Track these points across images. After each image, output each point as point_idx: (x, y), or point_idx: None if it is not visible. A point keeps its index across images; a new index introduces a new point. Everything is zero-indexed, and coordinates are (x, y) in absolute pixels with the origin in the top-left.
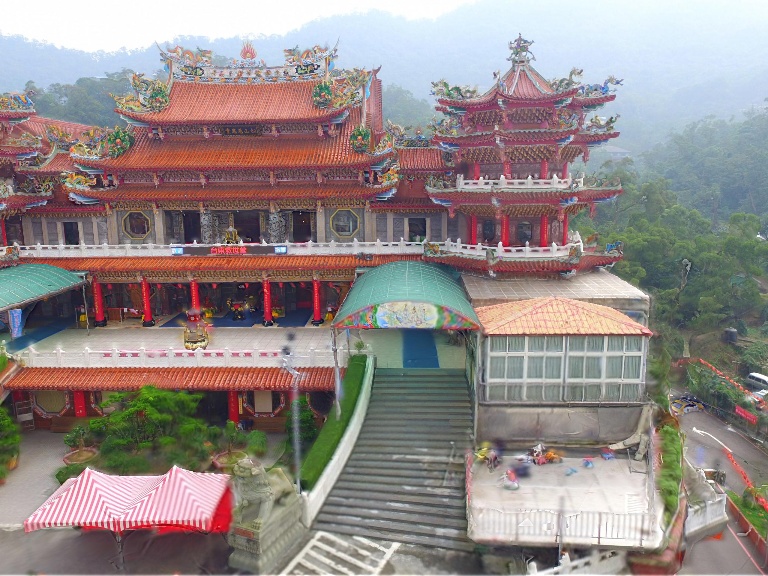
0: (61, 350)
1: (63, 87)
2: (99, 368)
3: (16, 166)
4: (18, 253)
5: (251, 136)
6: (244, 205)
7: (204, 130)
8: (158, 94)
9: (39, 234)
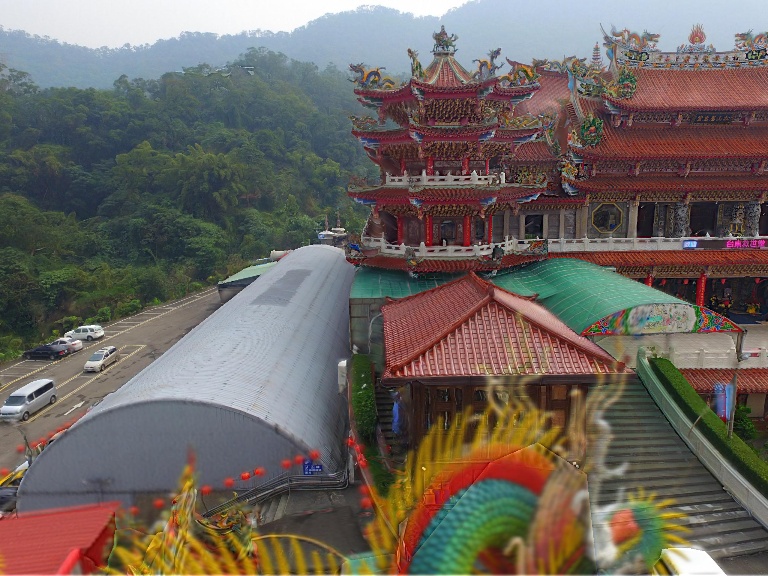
0: (704, 350)
1: (147, 82)
2: (747, 369)
3: (503, 155)
4: (547, 247)
5: (719, 124)
6: (728, 196)
7: (679, 117)
8: (625, 79)
9: (498, 228)
